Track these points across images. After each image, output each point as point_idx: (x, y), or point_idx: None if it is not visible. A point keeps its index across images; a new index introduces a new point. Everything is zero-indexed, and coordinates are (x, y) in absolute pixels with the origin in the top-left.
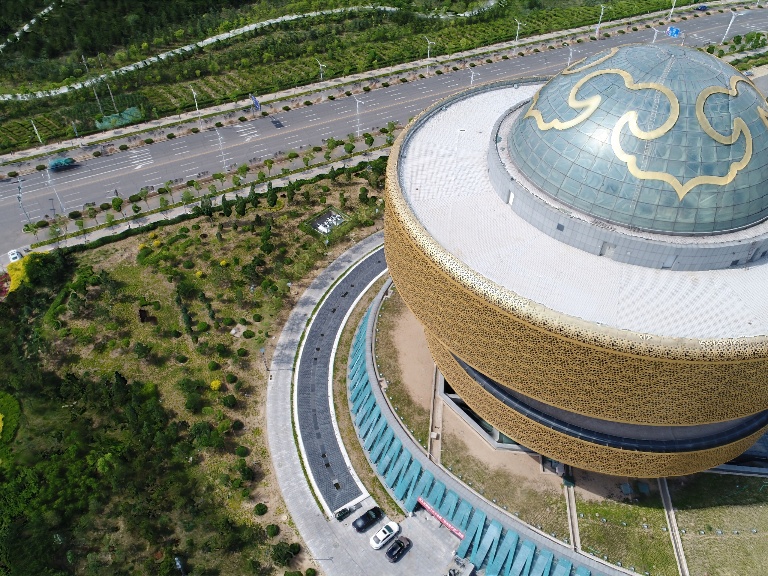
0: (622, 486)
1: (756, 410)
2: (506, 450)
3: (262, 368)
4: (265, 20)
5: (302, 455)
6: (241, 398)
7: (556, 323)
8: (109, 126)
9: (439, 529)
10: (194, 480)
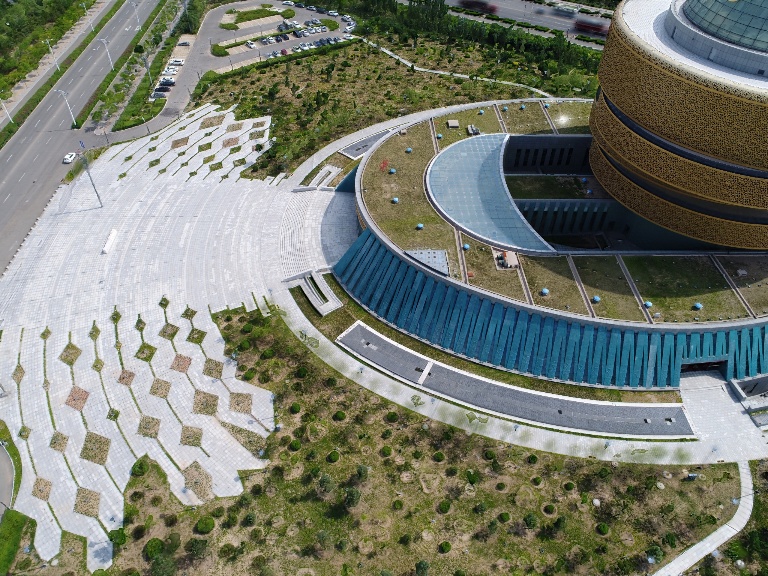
0: None
1: None
2: None
3: None
4: None
5: None
6: None
7: None
8: None
9: None
10: None
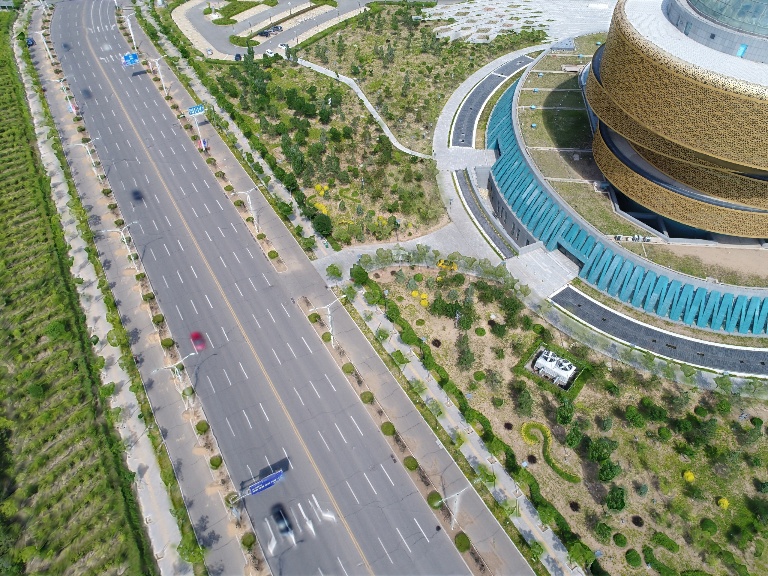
0: None
1: None
2: None
3: None
4: None
5: None
6: None
7: None
8: None
9: None
10: None
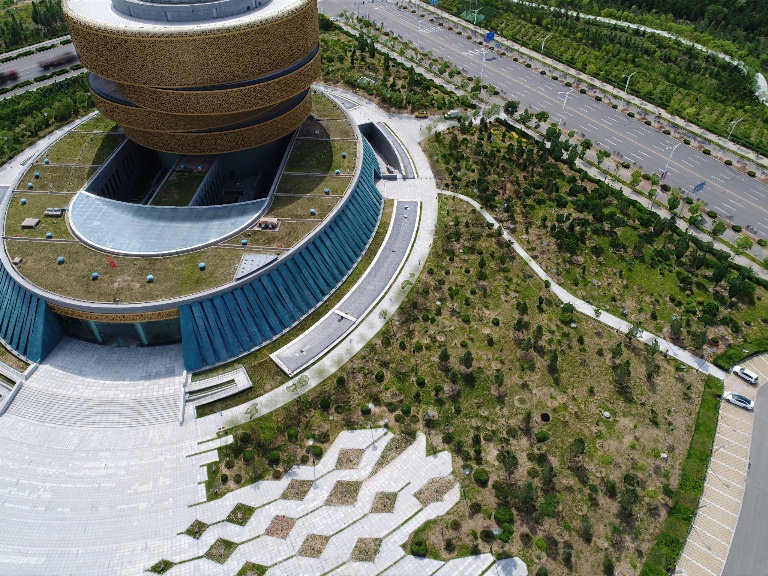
0: None
1: None
2: None
3: None
4: (647, 25)
5: None
6: None
7: None
8: (464, 17)
9: None
10: None
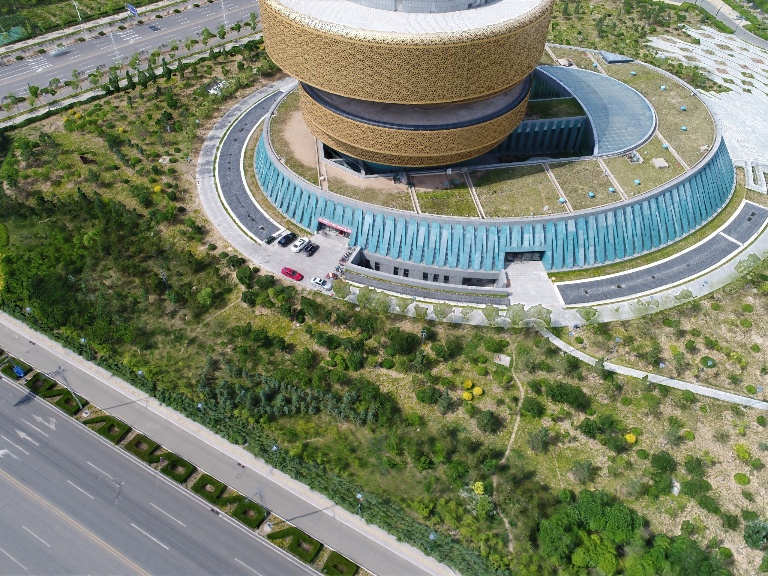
0: (443, 183)
1: (494, 88)
2: (370, 178)
3: (190, 178)
4: None
5: (234, 218)
6: (179, 195)
7: (371, 36)
8: None
9: (336, 237)
10: (160, 237)
